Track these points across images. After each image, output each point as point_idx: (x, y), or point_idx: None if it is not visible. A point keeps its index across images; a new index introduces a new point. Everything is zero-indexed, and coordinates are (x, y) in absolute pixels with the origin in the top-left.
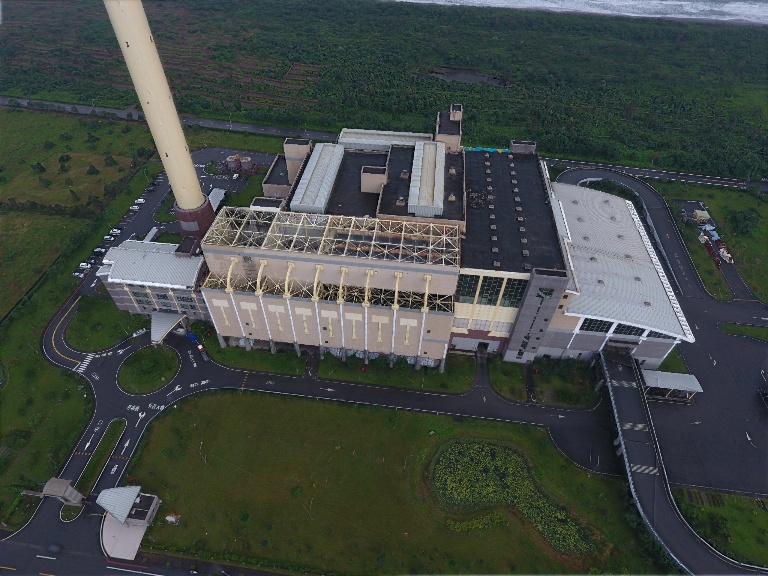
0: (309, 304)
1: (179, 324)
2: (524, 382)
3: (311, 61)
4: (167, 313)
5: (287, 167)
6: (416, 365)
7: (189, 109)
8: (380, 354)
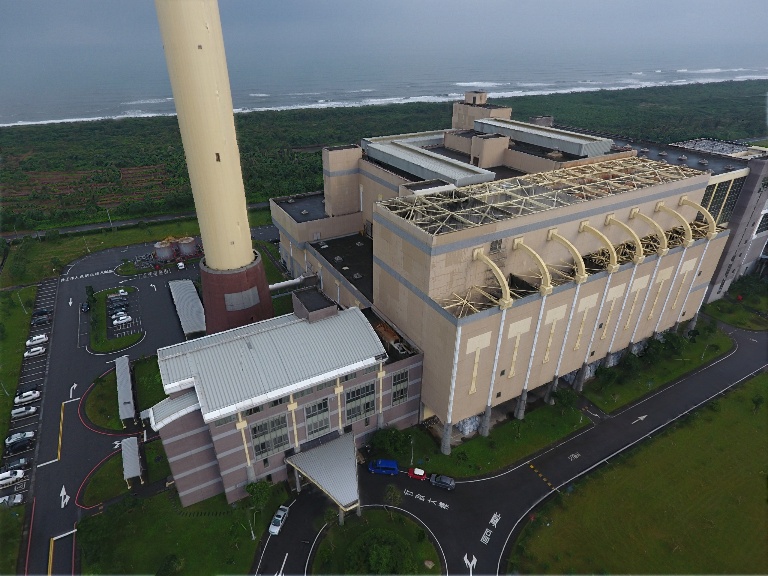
0: (601, 283)
1: None
2: (748, 311)
3: (144, 162)
4: (320, 446)
5: (330, 188)
6: None
7: (11, 225)
8: (649, 339)
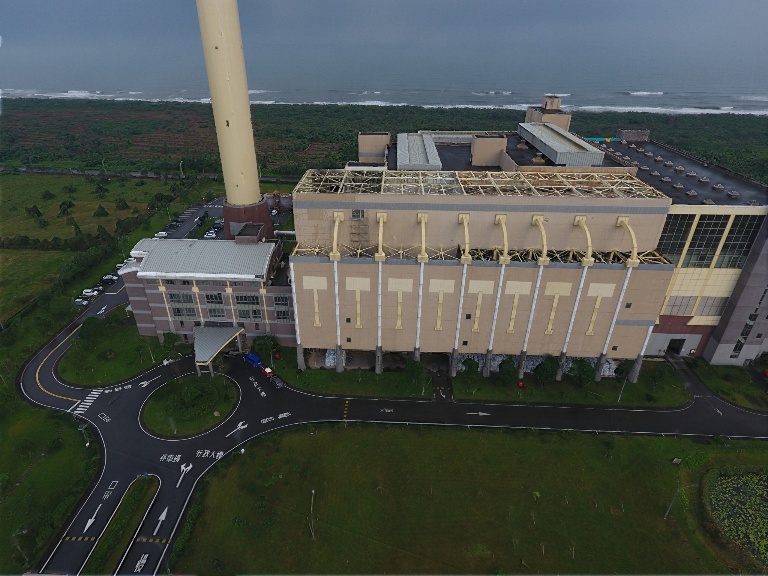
0: (454, 270)
1: (233, 343)
2: (759, 387)
3: (329, 140)
4: (216, 327)
5: None
6: (597, 373)
7: (210, 169)
8: (547, 355)
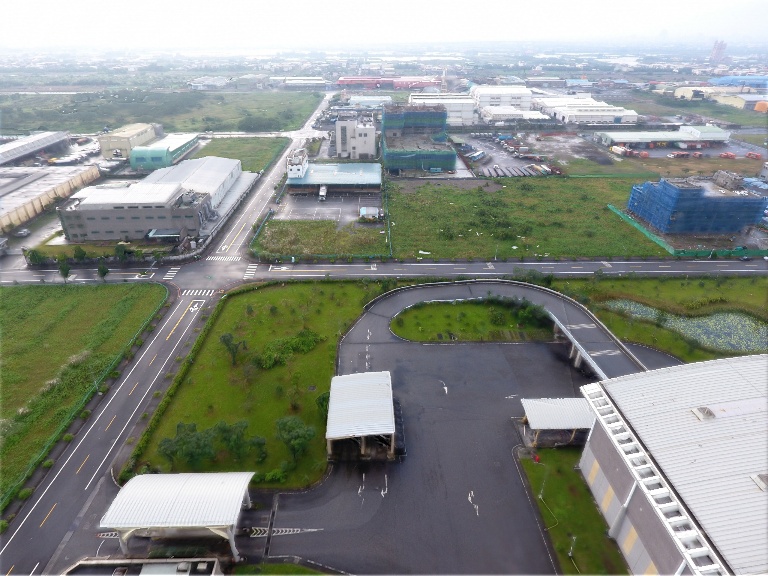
0: None
1: None
2: None
3: None
4: None
5: None
6: None
7: None
8: None
